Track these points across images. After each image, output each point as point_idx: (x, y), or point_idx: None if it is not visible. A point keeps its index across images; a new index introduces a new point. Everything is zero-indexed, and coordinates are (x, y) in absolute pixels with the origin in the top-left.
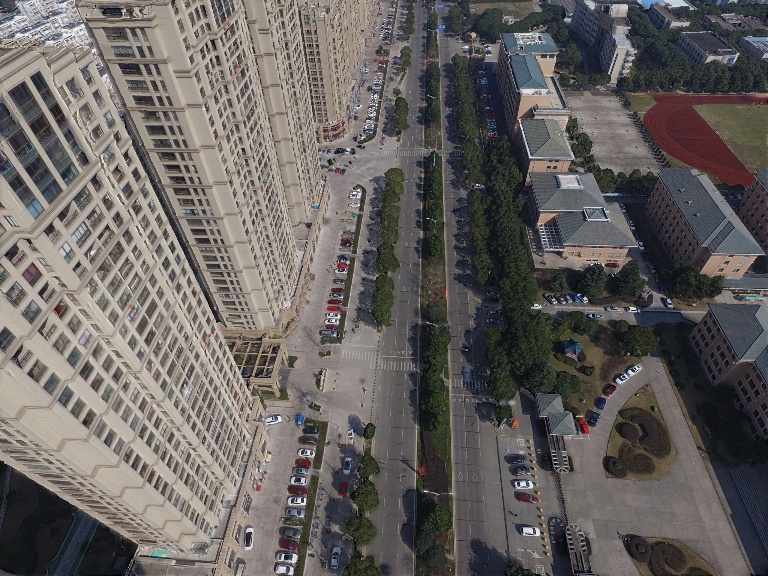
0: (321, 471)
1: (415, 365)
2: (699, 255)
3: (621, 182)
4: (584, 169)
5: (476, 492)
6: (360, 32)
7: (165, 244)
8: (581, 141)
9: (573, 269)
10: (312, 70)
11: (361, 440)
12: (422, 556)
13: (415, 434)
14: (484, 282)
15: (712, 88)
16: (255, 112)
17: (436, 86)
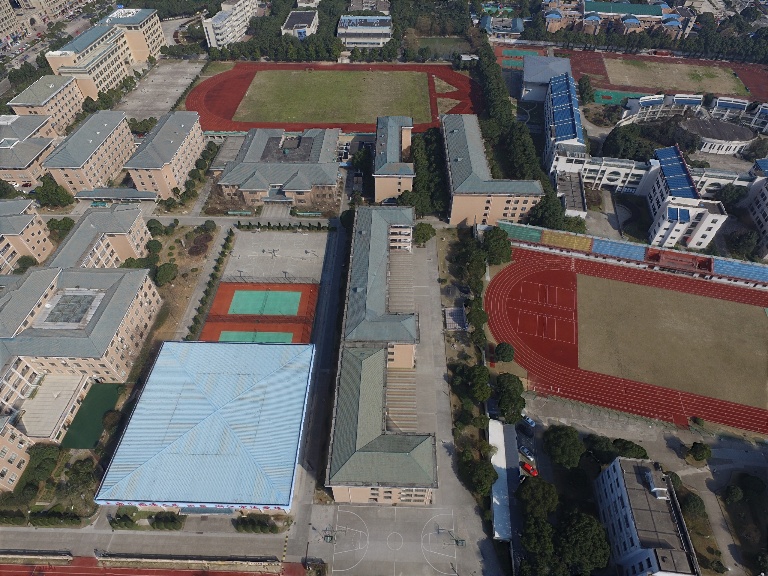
0: None
1: None
2: None
3: None
4: None
5: None
6: (8, 8)
7: None
8: (98, 95)
9: None
10: None
11: None
12: None
13: None
14: None
15: (285, 57)
16: None
17: None
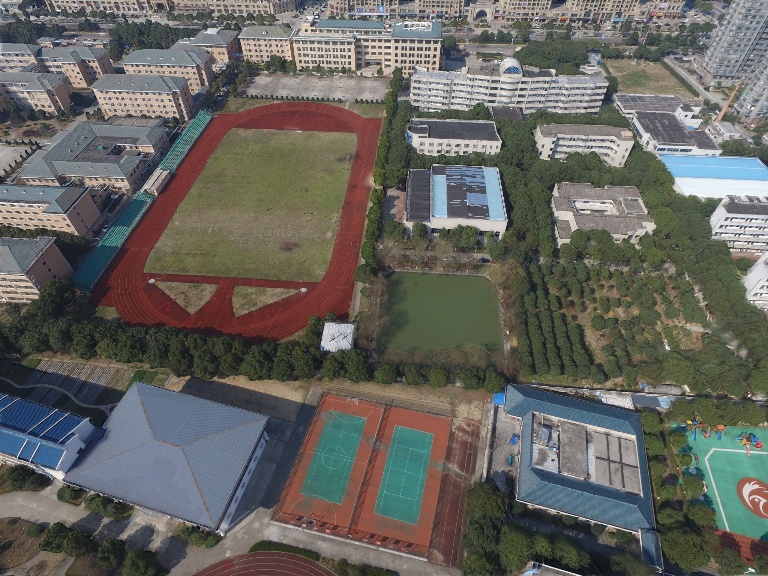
0: None
1: None
2: None
3: None
4: (267, 73)
5: None
6: None
7: None
8: None
9: None
10: None
11: None
12: None
13: None
14: None
15: None
16: None
17: None
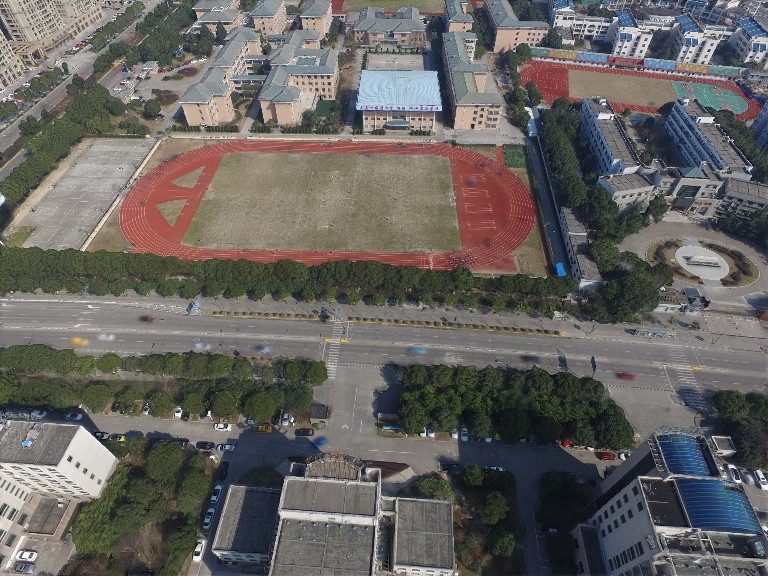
0: None
1: None
2: None
3: None
4: None
5: (105, 84)
6: None
7: None
8: None
9: None
10: None
11: None
12: None
13: (90, 74)
14: None
15: None
16: None
17: None
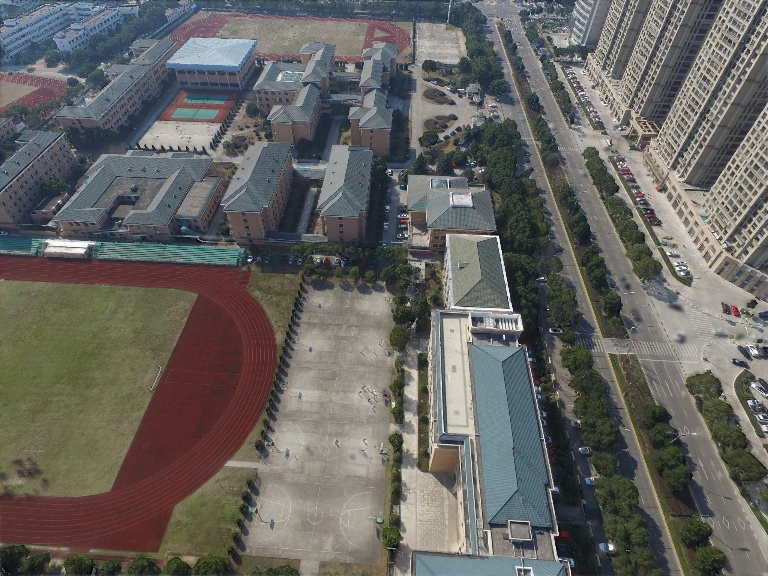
0: None
1: None
2: None
3: None
4: None
5: (515, 114)
6: None
7: None
8: None
9: None
10: None
11: (573, 126)
12: None
13: None
14: None
15: None
16: None
17: (709, 550)
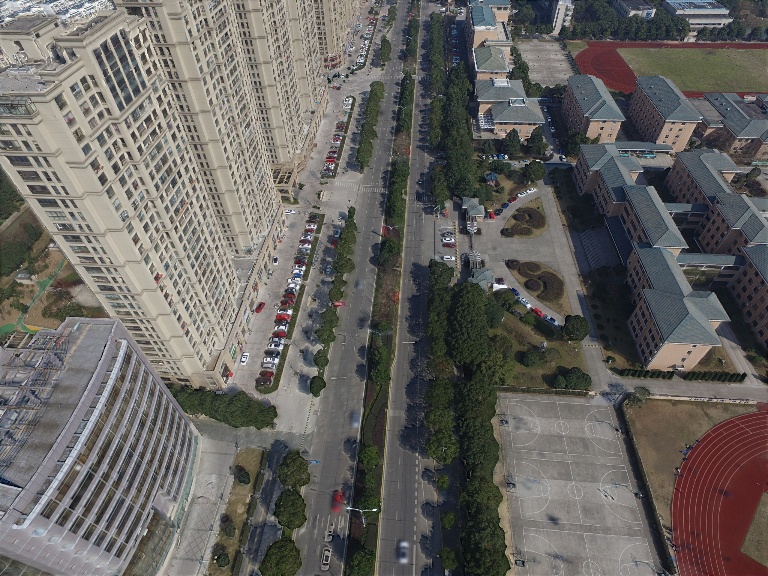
0: (320, 236)
1: (385, 189)
2: (584, 125)
3: (544, 90)
4: None
5: (418, 244)
6: None
7: (239, 44)
8: (520, 66)
9: (500, 139)
10: (316, 10)
11: None
12: (381, 264)
13: (382, 220)
14: (436, 144)
15: (633, 36)
16: (281, 1)
17: (414, 33)
